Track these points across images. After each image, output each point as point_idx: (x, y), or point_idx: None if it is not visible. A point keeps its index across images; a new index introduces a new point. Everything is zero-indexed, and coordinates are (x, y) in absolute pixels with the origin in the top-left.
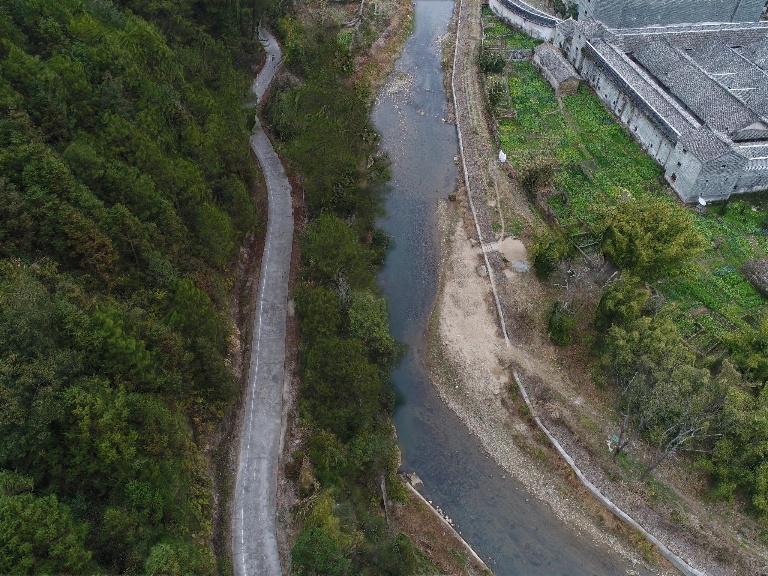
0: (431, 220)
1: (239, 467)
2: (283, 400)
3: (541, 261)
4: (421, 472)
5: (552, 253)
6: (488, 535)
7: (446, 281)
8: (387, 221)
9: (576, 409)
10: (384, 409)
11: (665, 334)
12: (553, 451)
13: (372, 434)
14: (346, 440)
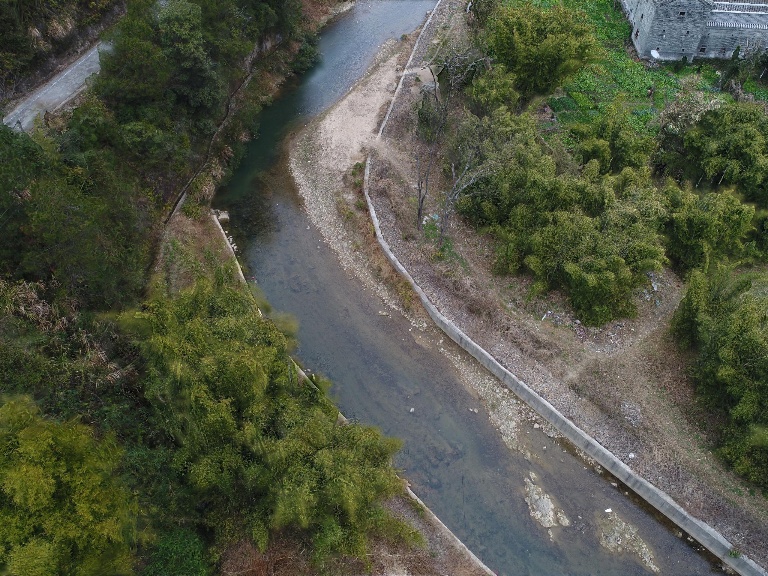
0: (372, 51)
1: (12, 112)
2: (85, 83)
3: (441, 71)
4: (234, 212)
5: (453, 64)
6: (264, 264)
7: (353, 91)
8: (329, 47)
9: (410, 190)
10: (224, 159)
11: (519, 125)
12: (366, 215)
13: (159, 129)
14: (126, 123)
